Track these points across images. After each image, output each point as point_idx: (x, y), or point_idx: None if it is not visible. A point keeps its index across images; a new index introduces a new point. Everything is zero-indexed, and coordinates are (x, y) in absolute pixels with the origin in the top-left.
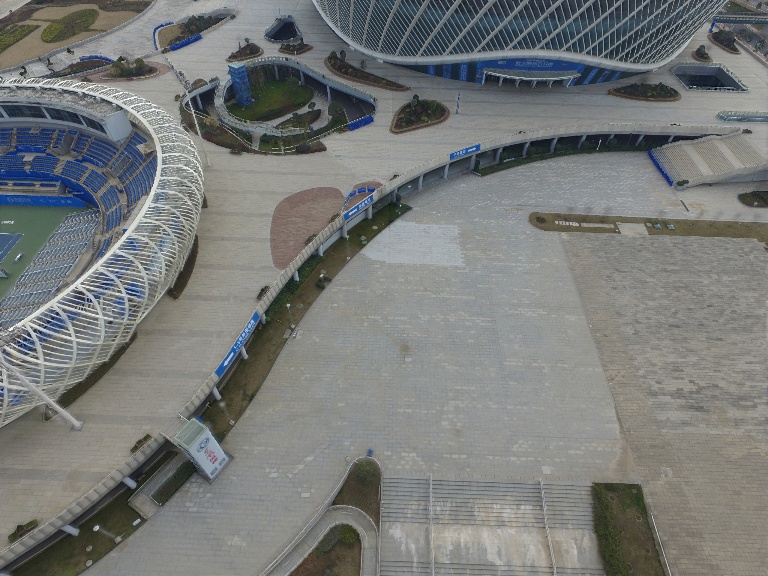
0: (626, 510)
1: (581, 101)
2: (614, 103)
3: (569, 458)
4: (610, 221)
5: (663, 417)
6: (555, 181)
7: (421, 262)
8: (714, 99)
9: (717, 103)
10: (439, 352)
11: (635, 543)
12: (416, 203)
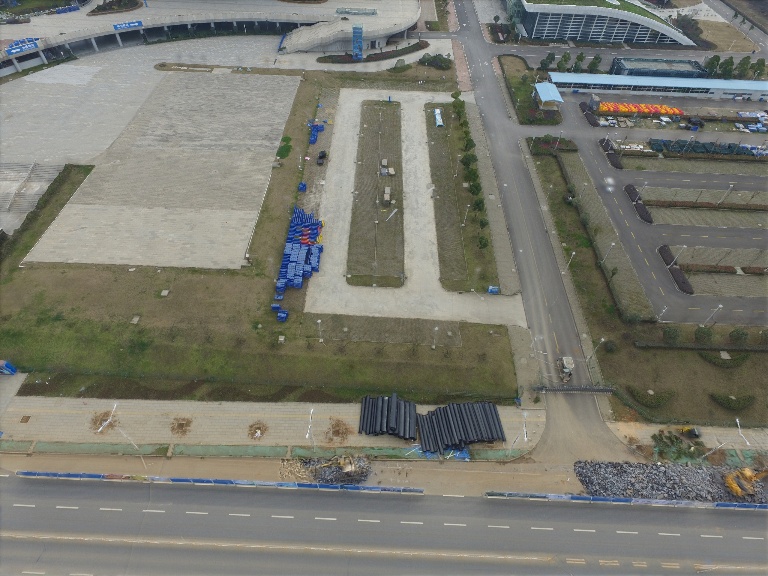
0: (78, 174)
1: (248, 2)
2: (271, 4)
3: (65, 156)
4: (211, 67)
5: (139, 143)
6: (197, 48)
7: (58, 82)
8: (349, 3)
9: (348, 5)
10: (30, 118)
11: (71, 184)
12: (85, 57)
